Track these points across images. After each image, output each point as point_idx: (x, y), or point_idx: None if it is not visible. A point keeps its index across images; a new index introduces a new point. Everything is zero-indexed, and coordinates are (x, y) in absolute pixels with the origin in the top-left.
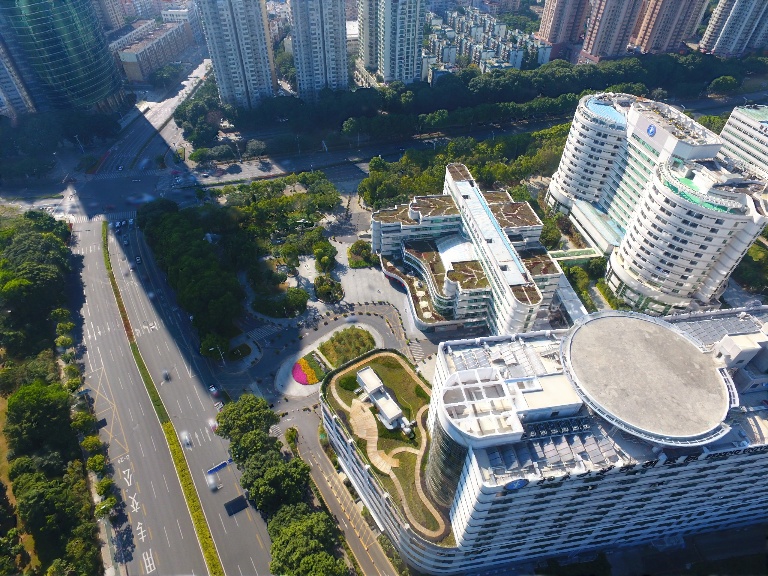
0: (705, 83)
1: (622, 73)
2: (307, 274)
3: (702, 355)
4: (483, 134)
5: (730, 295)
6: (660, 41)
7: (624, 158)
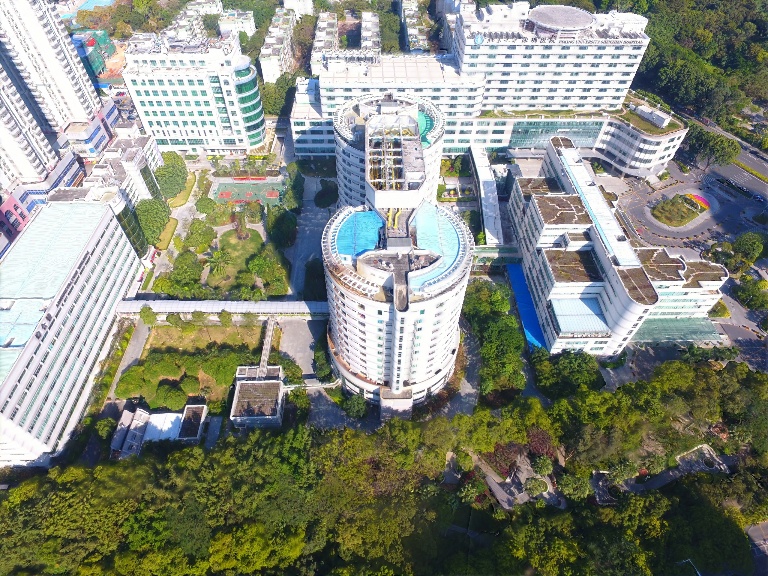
0: None
1: None
2: None
3: (532, 17)
4: None
5: (317, 224)
6: None
7: None
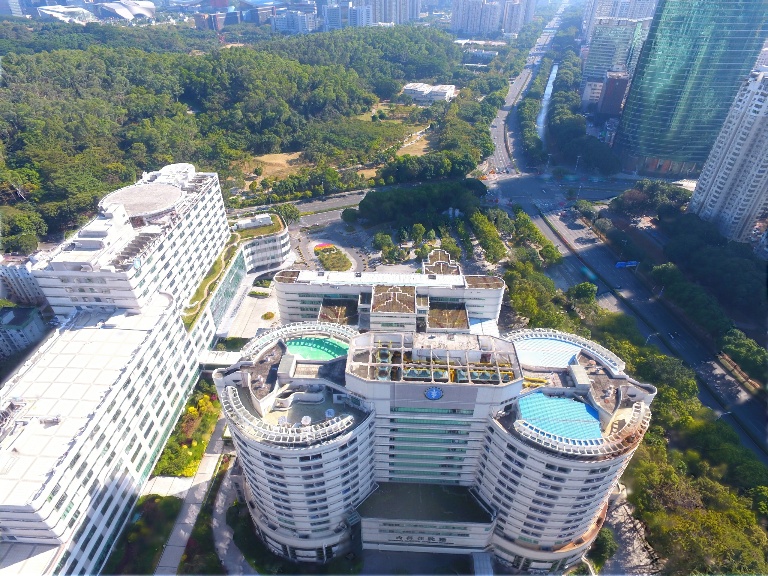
0: None
1: None
2: None
3: None
4: None
5: None
6: None
7: None
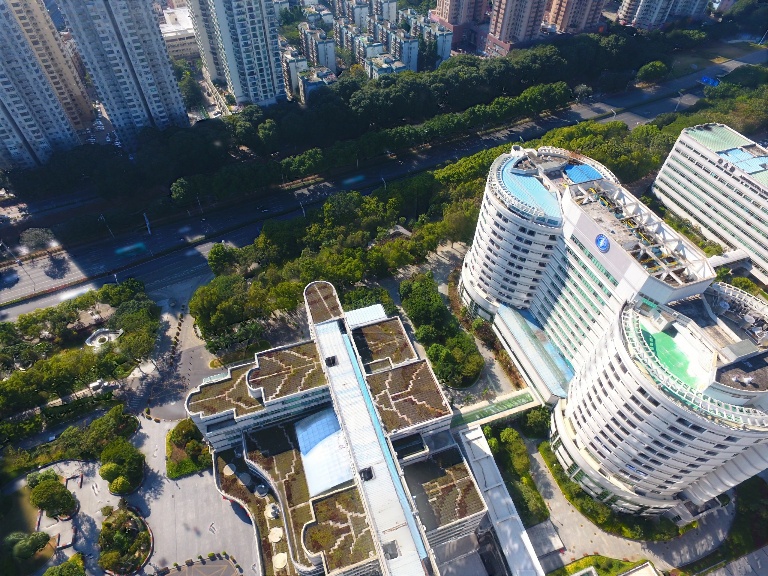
0: (633, 72)
1: (538, 67)
2: (93, 508)
3: None
4: (374, 171)
5: None
6: (577, 17)
7: (562, 265)
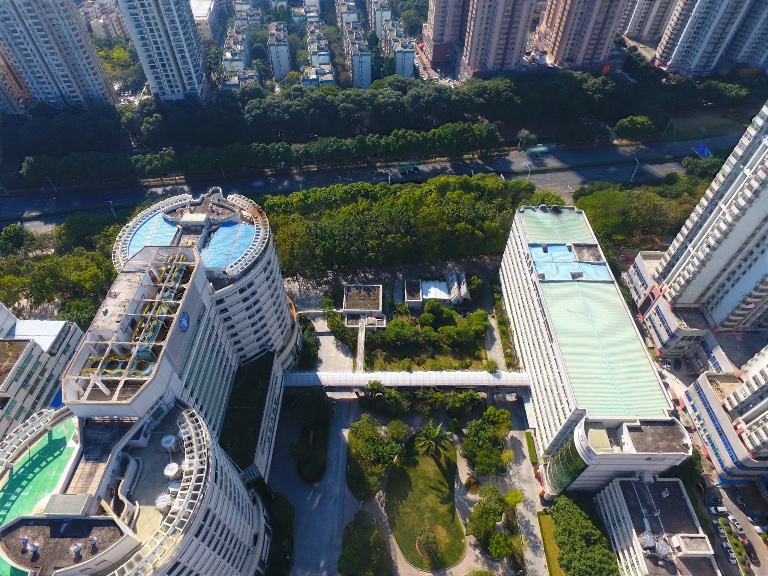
0: (602, 125)
1: (481, 101)
2: None
3: None
4: (239, 184)
5: None
6: (575, 50)
7: None
